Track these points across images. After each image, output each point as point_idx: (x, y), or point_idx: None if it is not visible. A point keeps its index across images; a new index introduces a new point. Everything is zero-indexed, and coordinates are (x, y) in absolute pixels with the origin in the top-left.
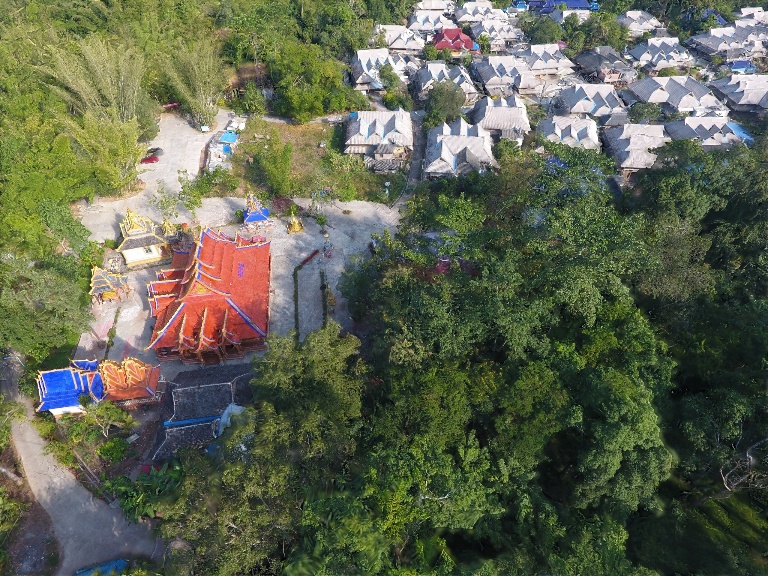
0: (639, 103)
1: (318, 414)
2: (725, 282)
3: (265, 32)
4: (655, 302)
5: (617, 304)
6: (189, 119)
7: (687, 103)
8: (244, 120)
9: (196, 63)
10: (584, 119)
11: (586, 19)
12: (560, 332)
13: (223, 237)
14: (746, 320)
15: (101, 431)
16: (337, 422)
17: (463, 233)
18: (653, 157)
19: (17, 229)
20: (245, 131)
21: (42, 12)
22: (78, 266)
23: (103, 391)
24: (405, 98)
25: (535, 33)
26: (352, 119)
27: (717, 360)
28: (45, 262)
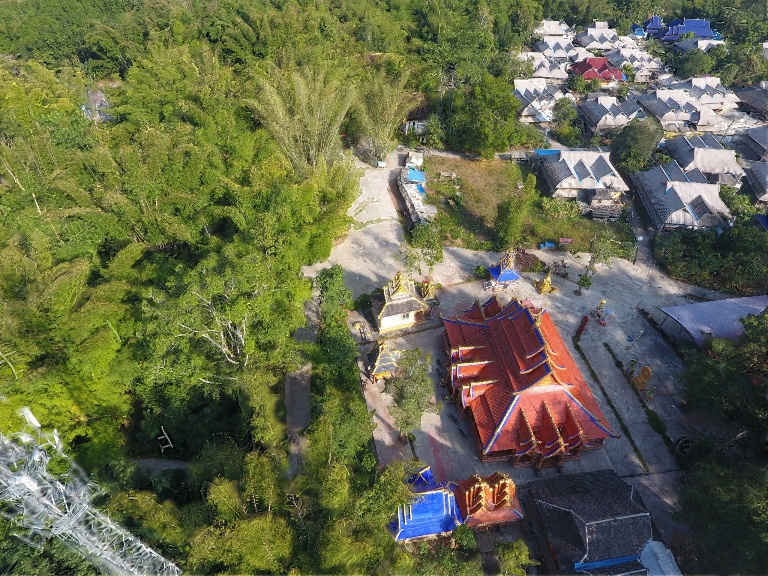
0: None
1: None
2: None
3: (459, 63)
4: None
5: None
6: (353, 151)
7: None
8: (421, 155)
9: (388, 95)
10: None
11: None
12: None
13: None
14: None
15: (502, 575)
16: None
17: None
18: None
19: (296, 298)
20: None
21: (183, 32)
22: (353, 339)
23: (469, 514)
24: (581, 133)
25: (684, 64)
26: (549, 158)
27: None
28: (331, 338)
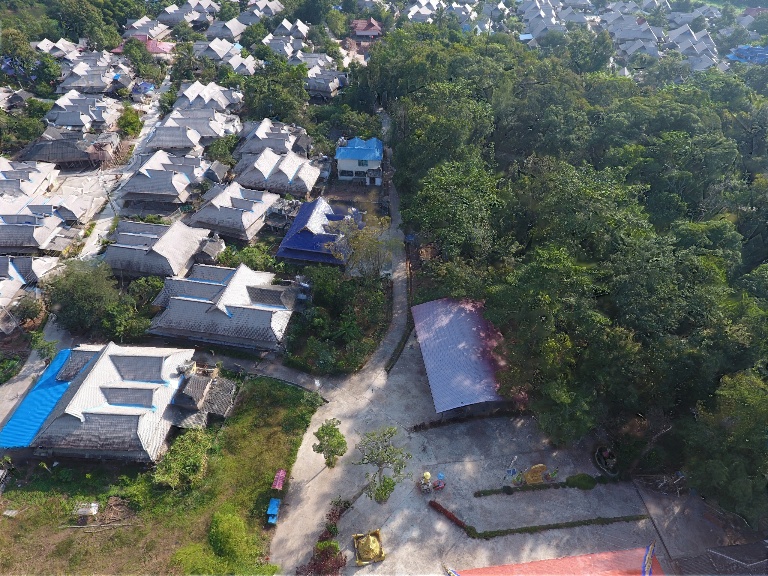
0: (212, 147)
1: None
2: None
3: None
4: None
5: None
6: None
7: (217, 128)
8: None
9: None
10: (230, 185)
11: None
12: None
13: None
14: None
15: None
16: None
17: None
18: (311, 169)
19: None
20: None
21: None
22: None
23: None
24: None
25: None
26: (55, 435)
27: None
28: None
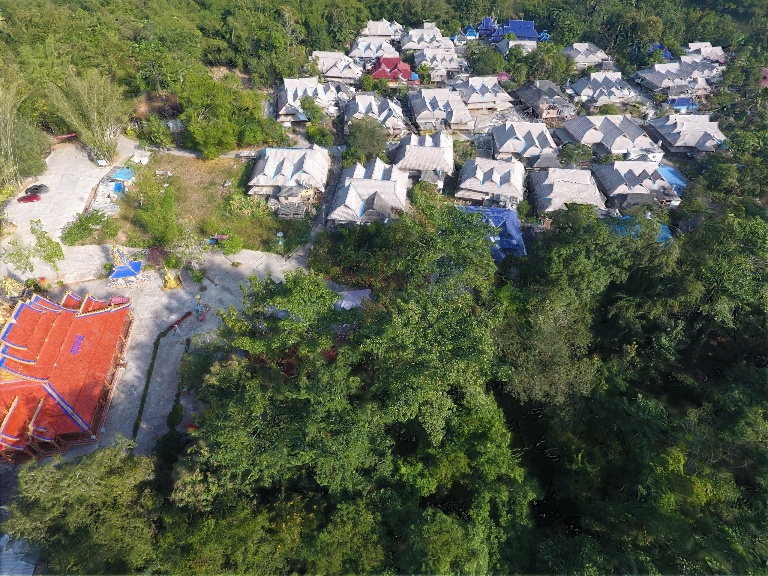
0: (569, 144)
1: (74, 572)
2: (618, 372)
3: (166, 61)
4: (525, 407)
5: (474, 414)
6: None
7: (621, 144)
8: (147, 154)
9: (87, 93)
10: (508, 162)
11: (531, 51)
12: (407, 447)
13: (72, 300)
14: (633, 425)
15: None
16: (122, 566)
17: (310, 317)
18: None
19: None
20: (147, 166)
21: None
22: None
23: None
24: None
25: (476, 64)
26: (262, 156)
27: (592, 481)
28: None
